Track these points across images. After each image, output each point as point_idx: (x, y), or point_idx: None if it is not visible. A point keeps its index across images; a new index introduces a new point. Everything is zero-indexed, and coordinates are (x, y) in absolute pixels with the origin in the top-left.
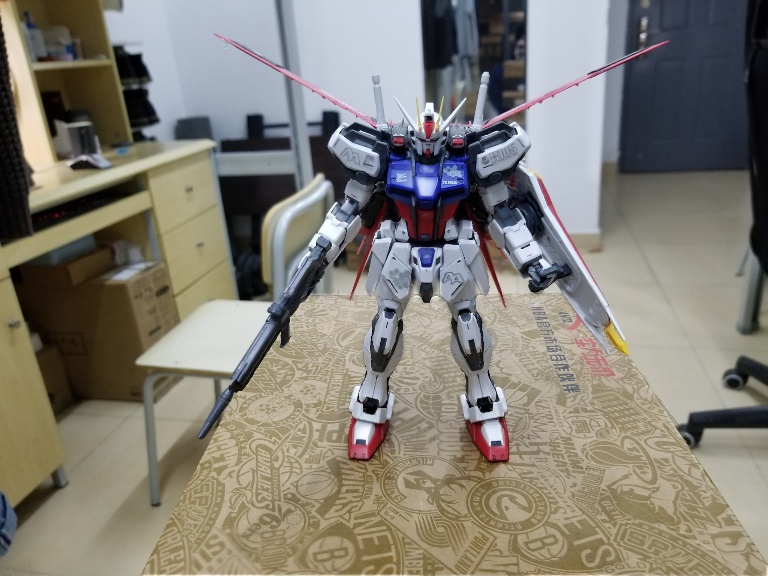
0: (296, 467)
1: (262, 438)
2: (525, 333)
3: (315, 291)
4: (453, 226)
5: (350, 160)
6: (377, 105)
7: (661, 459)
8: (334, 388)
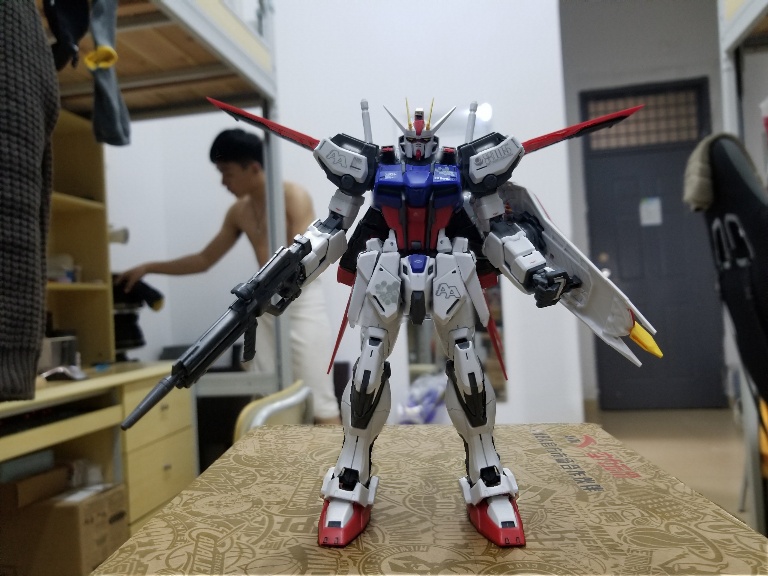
0: (247, 552)
1: (207, 527)
2: (529, 450)
3: None
4: (446, 237)
5: (336, 163)
6: (366, 130)
7: (721, 539)
8: (304, 490)
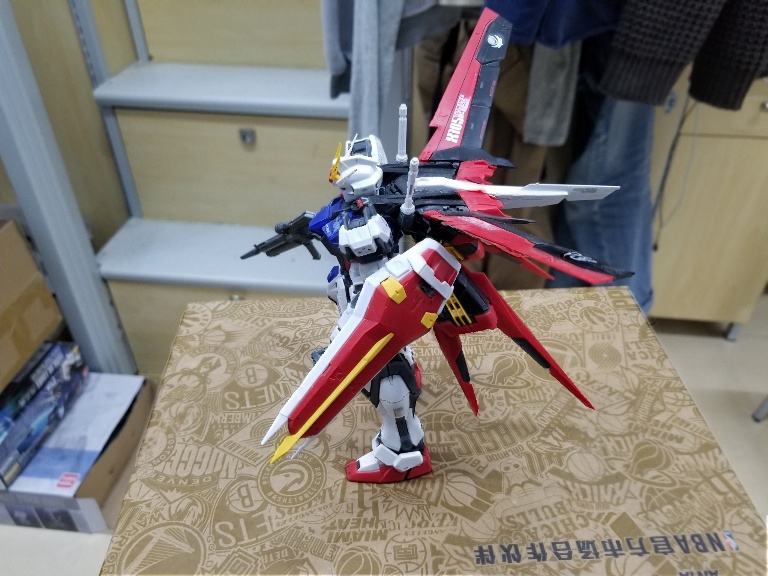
0: None
1: None
2: (624, 518)
3: (644, 305)
4: (353, 271)
5: None
6: None
7: None
8: None
